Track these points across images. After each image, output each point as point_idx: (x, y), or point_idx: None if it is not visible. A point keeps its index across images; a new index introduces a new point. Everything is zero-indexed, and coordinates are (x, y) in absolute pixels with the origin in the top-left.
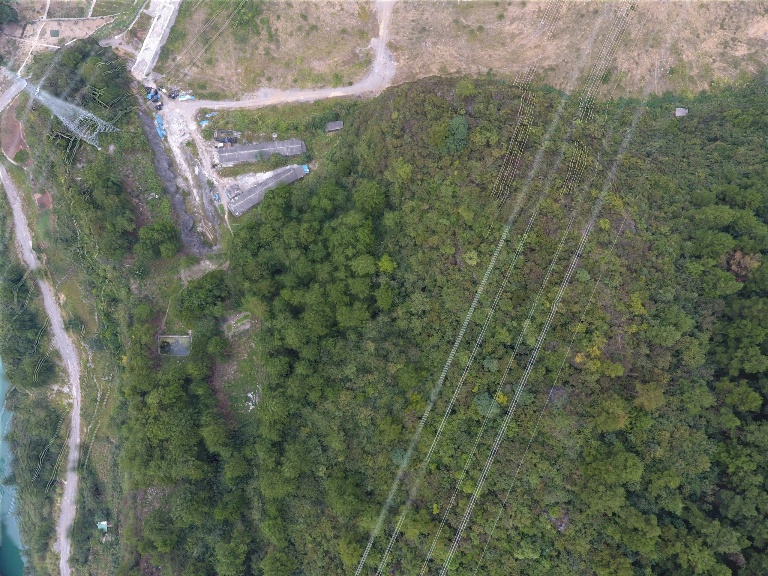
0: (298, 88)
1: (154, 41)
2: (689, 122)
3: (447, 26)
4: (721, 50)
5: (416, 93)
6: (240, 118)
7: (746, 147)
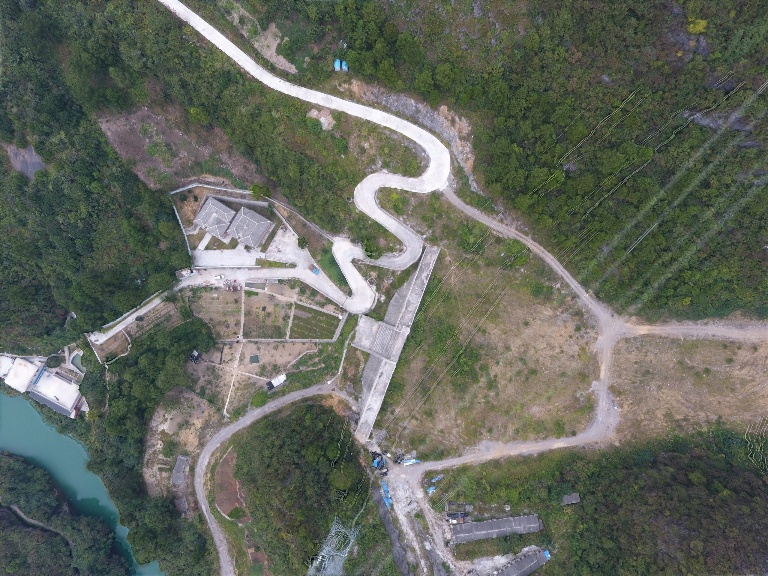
0: (520, 440)
1: (376, 401)
2: None
3: (671, 368)
4: None
5: (721, 568)
6: (468, 485)
7: None
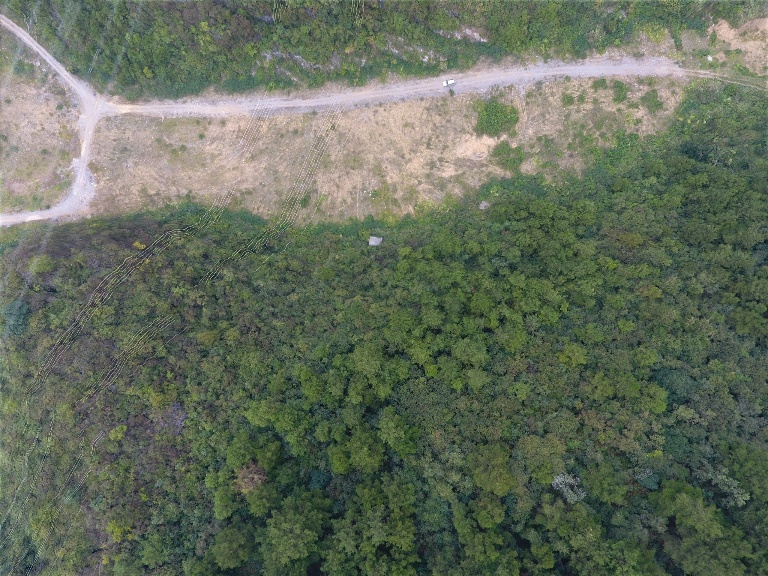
0: None
1: None
2: (364, 259)
3: (149, 145)
4: (427, 171)
5: None
6: None
7: (384, 303)
